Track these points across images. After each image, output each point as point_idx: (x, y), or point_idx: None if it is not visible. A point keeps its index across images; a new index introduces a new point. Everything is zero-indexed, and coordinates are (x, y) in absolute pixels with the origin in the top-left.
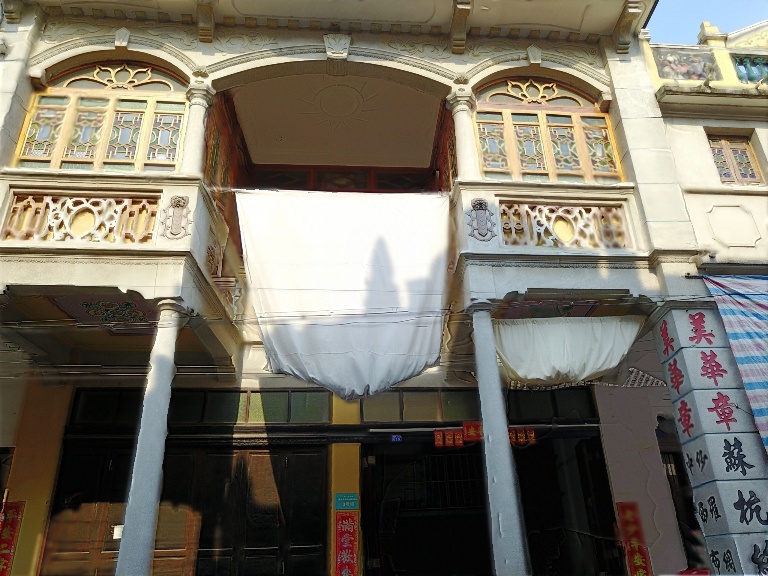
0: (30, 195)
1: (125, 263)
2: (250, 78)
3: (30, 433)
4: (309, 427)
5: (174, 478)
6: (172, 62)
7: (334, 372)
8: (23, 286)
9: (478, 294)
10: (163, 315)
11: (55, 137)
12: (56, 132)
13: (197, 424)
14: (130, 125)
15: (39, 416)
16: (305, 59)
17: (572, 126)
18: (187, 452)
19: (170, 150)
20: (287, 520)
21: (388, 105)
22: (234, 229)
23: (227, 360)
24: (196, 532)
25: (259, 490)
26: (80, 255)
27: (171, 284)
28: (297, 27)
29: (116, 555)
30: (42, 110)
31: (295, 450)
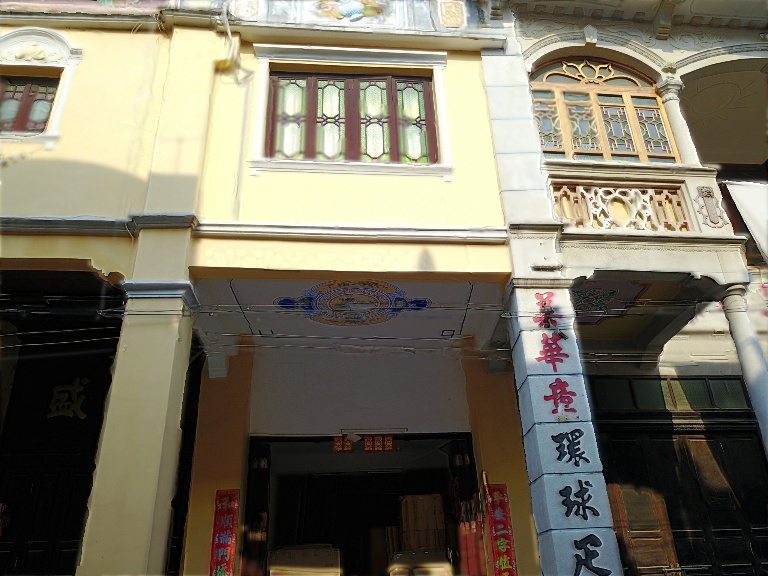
0: (564, 185)
1: (689, 250)
2: (700, 75)
3: (489, 418)
4: (740, 413)
5: (627, 462)
6: (639, 58)
7: None
8: (606, 271)
9: None
10: (734, 300)
11: (557, 130)
12: (555, 125)
13: (640, 410)
14: (617, 119)
15: (491, 402)
16: (752, 57)
17: None
18: (634, 437)
19: (663, 143)
20: (741, 503)
21: (759, 103)
22: (737, 219)
23: (659, 348)
24: (664, 514)
25: (707, 474)
26: (647, 242)
27: (739, 270)
28: (737, 26)
29: None
30: (535, 103)
31: (729, 436)
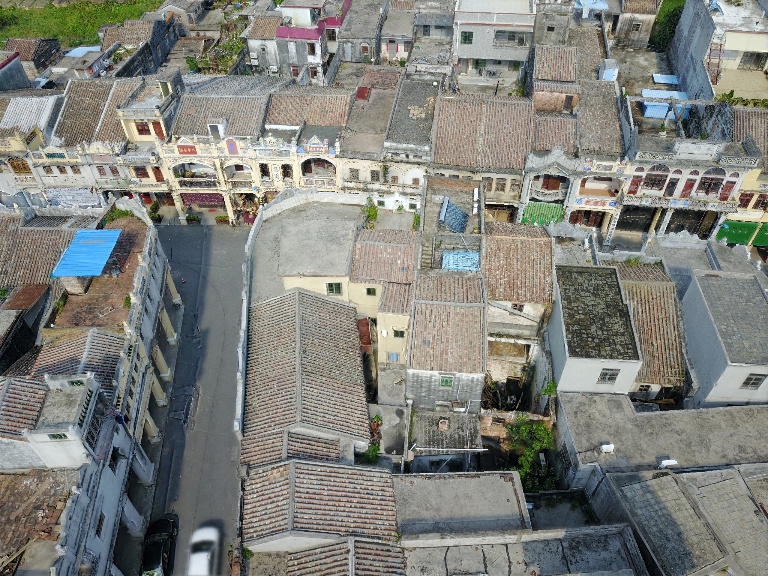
0: None
1: None
2: None
3: None
4: None
5: None
6: None
7: (9, 193)
8: None
9: (20, 188)
10: None
11: None
12: None
13: None
14: None
15: None
16: None
17: (25, 164)
18: None
19: None
20: None
21: None
22: None
23: None
24: None
25: None
26: None
27: None
28: None
29: (1, 192)
30: None
31: None
